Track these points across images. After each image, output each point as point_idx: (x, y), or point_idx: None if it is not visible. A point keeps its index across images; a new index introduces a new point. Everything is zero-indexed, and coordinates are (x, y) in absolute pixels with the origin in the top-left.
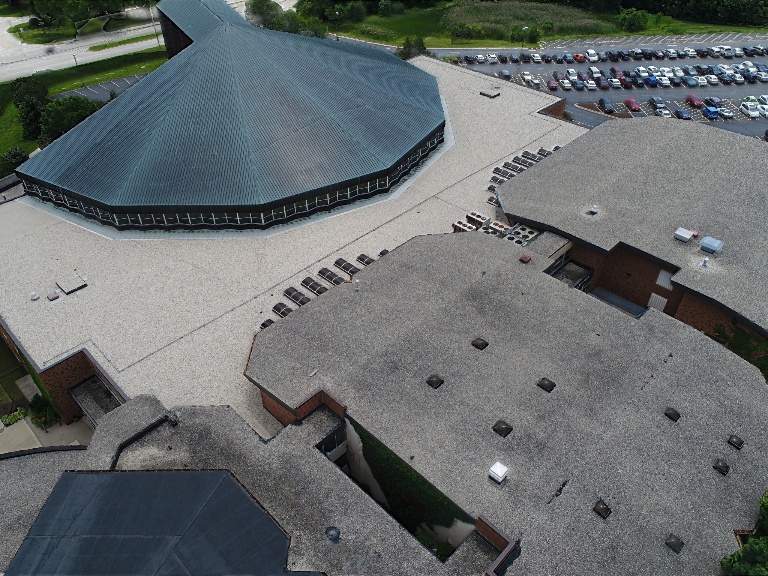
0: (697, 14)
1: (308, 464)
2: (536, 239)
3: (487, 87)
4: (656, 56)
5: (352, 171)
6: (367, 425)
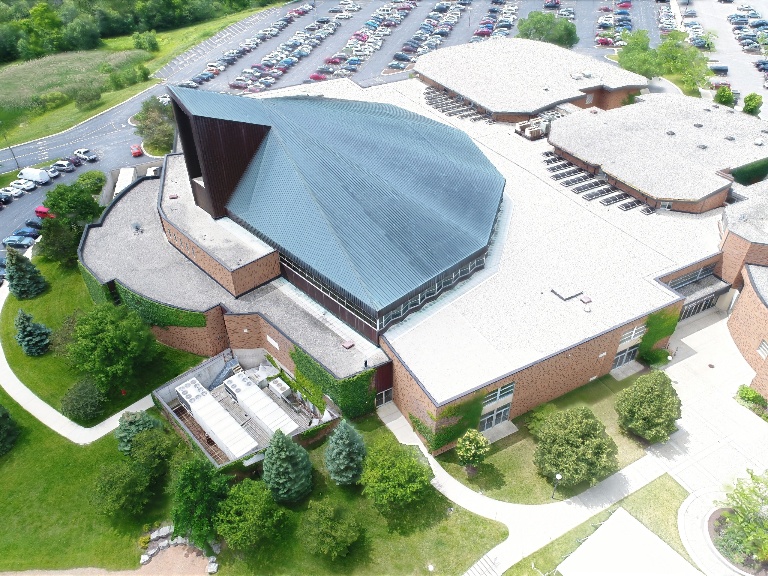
0: (167, 24)
1: (759, 189)
2: (565, 109)
3: (300, 94)
4: (246, 51)
5: (468, 141)
6: (738, 165)
